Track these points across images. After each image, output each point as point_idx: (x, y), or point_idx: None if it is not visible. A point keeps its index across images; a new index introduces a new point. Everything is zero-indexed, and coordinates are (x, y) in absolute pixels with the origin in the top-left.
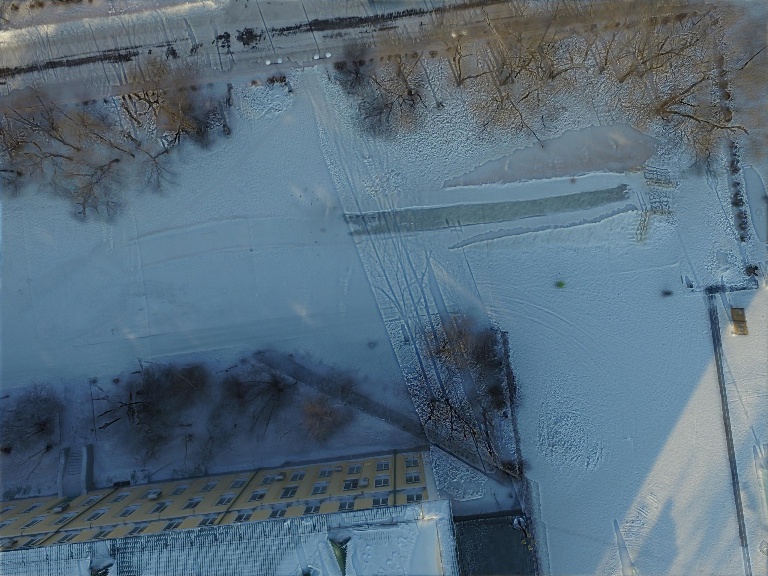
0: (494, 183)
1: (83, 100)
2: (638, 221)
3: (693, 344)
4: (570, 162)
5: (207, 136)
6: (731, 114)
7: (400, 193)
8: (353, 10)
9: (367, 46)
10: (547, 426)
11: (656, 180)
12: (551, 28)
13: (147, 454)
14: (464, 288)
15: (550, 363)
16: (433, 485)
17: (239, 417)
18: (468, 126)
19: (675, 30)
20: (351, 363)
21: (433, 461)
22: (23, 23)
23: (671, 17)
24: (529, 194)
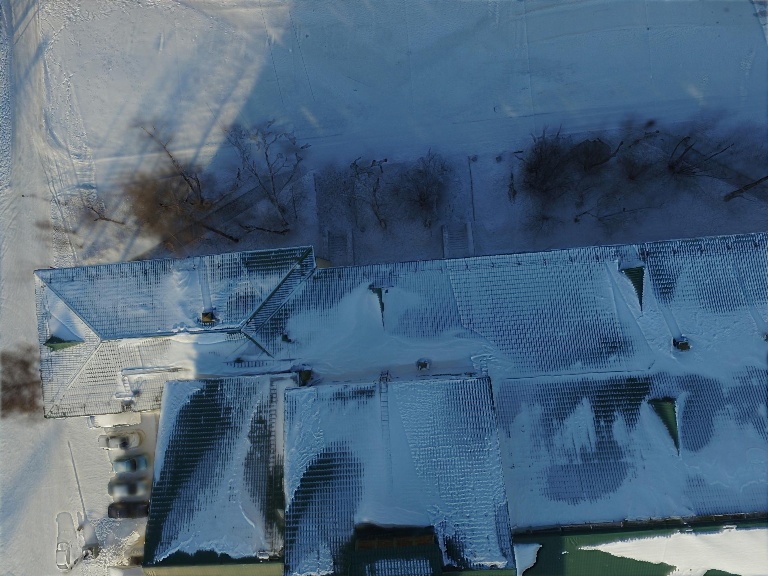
0: None
1: None
2: None
3: None
4: None
5: None
6: None
7: None
8: None
9: None
10: None
11: None
12: None
13: (541, 229)
14: None
15: None
16: None
17: (635, 197)
18: None
19: None
20: (751, 148)
21: None
22: None
23: None
24: None
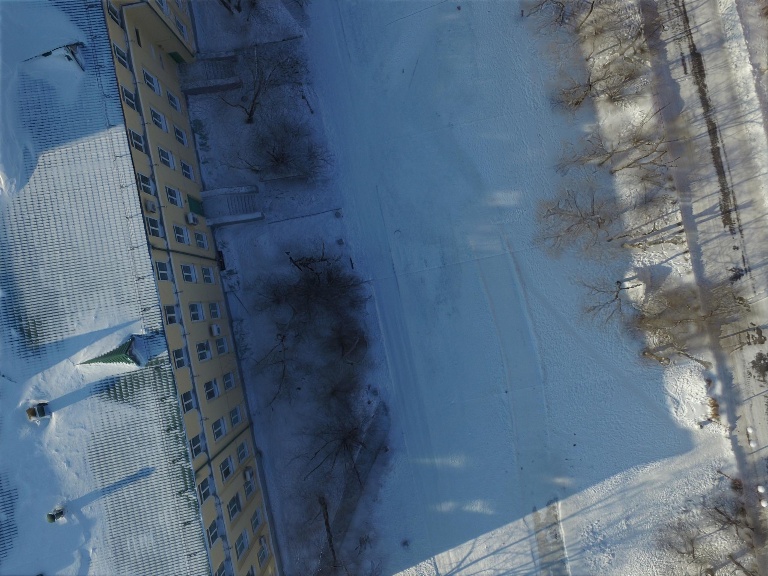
0: None
1: None
2: None
3: None
4: None
5: None
6: None
7: (588, 567)
8: None
9: (761, 511)
10: None
11: None
12: None
13: (260, 294)
14: None
15: None
16: None
17: None
18: None
19: None
20: (383, 521)
21: None
22: (763, 92)
23: None
24: None
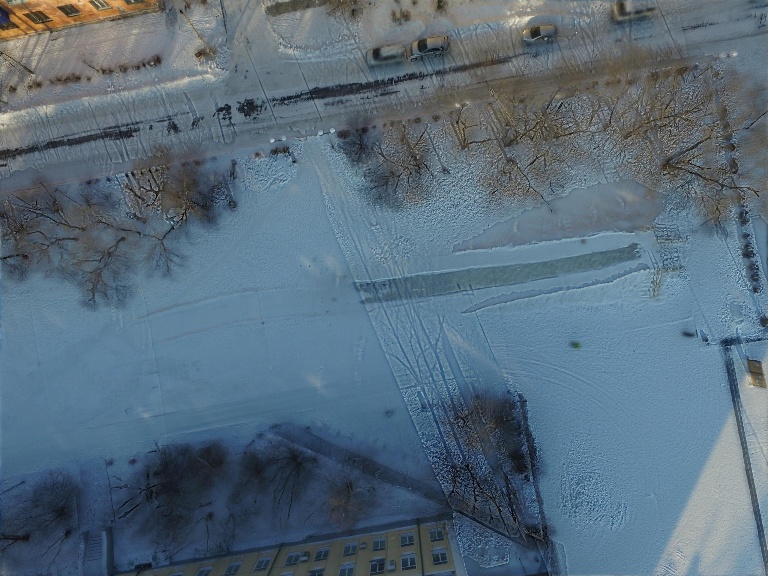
0: (504, 246)
1: (86, 179)
2: (650, 279)
3: (711, 398)
4: (579, 221)
5: (213, 210)
6: (737, 166)
7: (410, 259)
8: (353, 76)
9: (369, 112)
10: (569, 487)
11: (666, 237)
12: (552, 86)
13: (168, 536)
14: (479, 352)
15: (569, 423)
16: (462, 569)
17: (259, 493)
18: (475, 189)
19: (677, 84)
20: (369, 433)
21: (456, 528)
22: (22, 104)
23: (672, 71)
24: (540, 256)
